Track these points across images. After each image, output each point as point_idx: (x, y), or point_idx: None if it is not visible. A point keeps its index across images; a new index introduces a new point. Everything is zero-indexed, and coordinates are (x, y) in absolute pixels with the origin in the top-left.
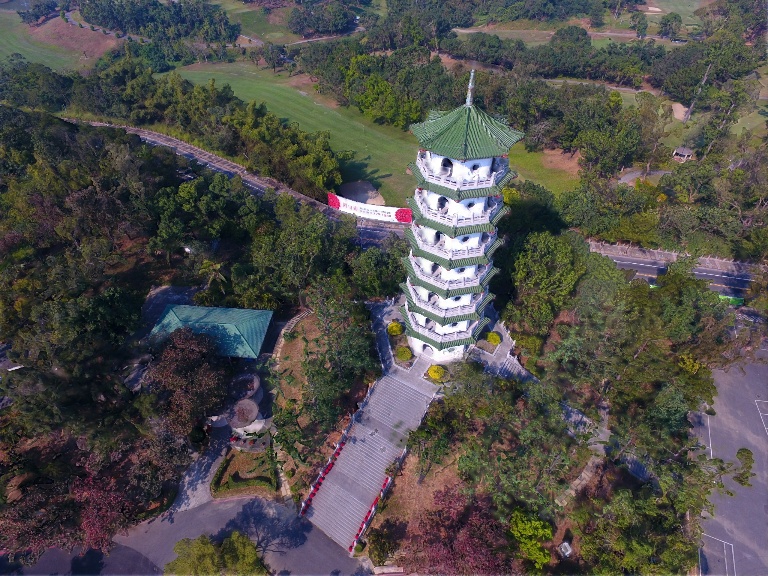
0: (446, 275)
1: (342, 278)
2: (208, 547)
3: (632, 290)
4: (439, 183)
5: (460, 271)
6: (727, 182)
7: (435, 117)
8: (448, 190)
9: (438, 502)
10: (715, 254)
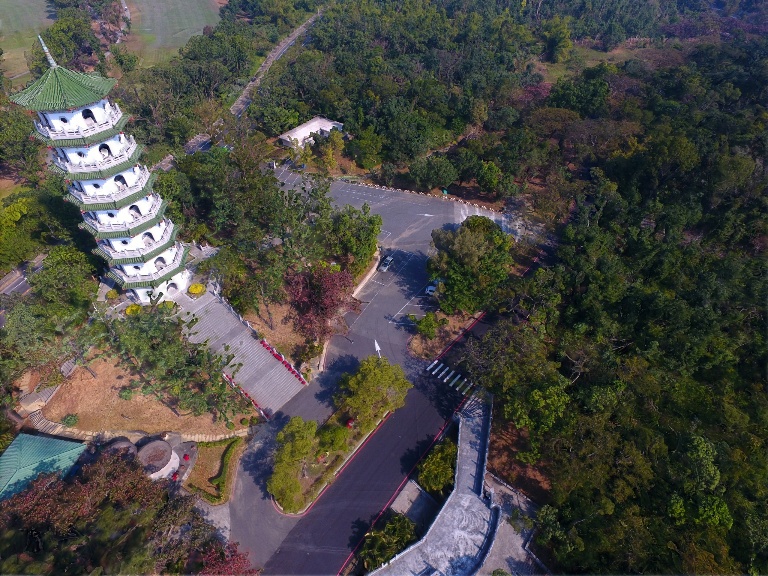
0: (144, 209)
1: (85, 284)
2: (286, 447)
3: (189, 173)
4: (96, 131)
5: (147, 200)
6: (122, 108)
7: (25, 97)
8: (106, 132)
9: (298, 297)
10: (166, 154)
